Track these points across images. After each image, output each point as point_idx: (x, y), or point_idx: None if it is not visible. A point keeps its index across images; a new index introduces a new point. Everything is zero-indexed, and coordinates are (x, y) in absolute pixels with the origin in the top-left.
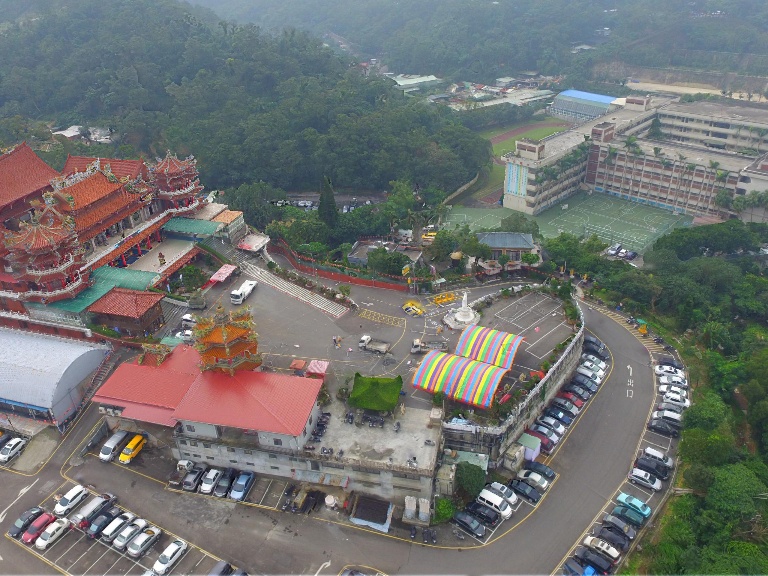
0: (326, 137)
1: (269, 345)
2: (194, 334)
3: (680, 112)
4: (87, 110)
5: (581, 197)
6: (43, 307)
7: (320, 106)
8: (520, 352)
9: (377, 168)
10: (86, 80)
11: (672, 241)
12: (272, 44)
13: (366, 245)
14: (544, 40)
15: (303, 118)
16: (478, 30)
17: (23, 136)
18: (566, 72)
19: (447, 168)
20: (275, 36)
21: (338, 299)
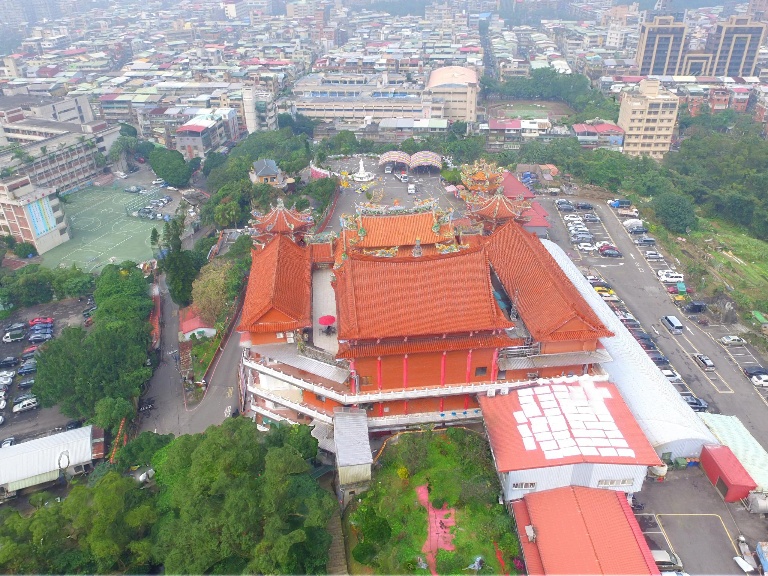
0: None
1: None
2: (502, 170)
3: None
4: None
5: None
6: None
7: None
8: (384, 164)
9: None
10: None
11: (184, 169)
12: None
13: None
14: None
15: None
16: None
17: None
18: None
19: None
20: None
21: None
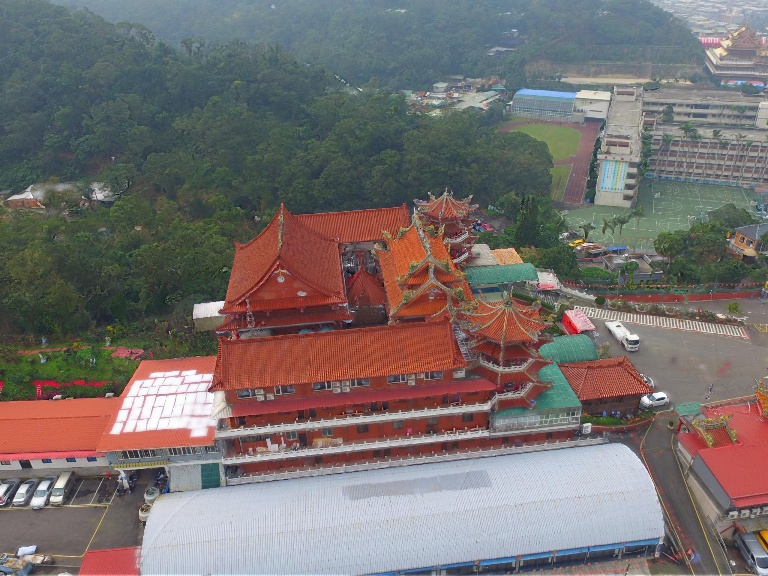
0: (414, 157)
1: (746, 385)
2: None
3: (665, 99)
4: (50, 162)
5: (645, 185)
6: (525, 412)
7: (387, 125)
8: None
9: (470, 184)
10: (38, 124)
11: None
12: (262, 62)
13: (581, 263)
14: (465, 44)
15: (365, 140)
16: (396, 38)
17: (56, 205)
18: (493, 73)
19: (538, 174)
20: (262, 53)
21: (723, 320)
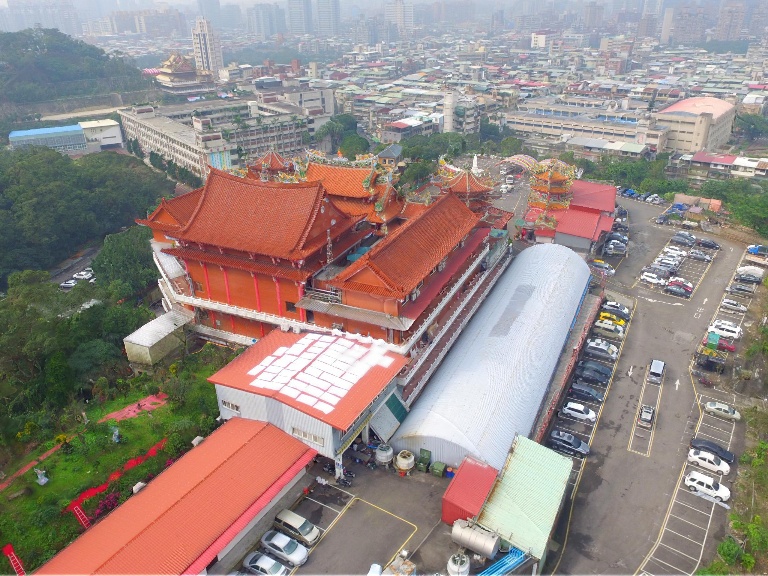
0: (52, 186)
1: None
2: None
3: (177, 111)
4: None
5: None
6: None
7: None
8: None
9: (114, 203)
10: None
11: None
12: None
13: None
14: None
15: None
16: None
17: None
18: None
19: (162, 180)
20: None
21: None
